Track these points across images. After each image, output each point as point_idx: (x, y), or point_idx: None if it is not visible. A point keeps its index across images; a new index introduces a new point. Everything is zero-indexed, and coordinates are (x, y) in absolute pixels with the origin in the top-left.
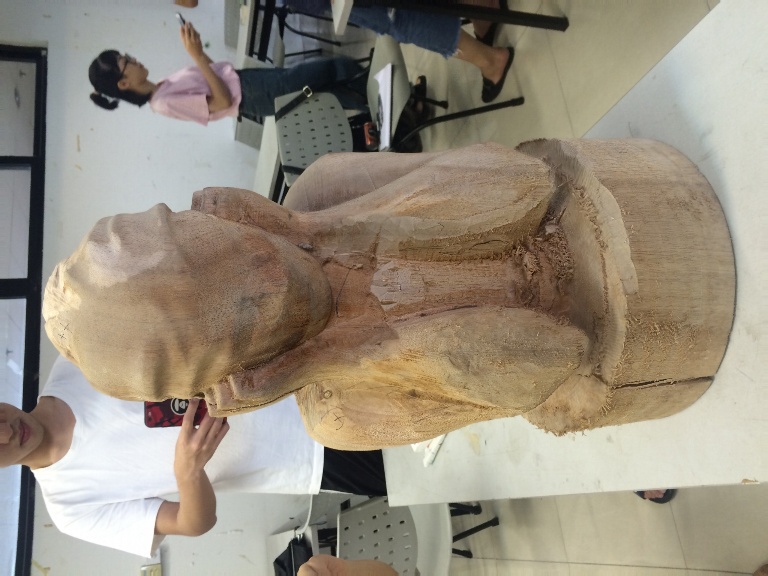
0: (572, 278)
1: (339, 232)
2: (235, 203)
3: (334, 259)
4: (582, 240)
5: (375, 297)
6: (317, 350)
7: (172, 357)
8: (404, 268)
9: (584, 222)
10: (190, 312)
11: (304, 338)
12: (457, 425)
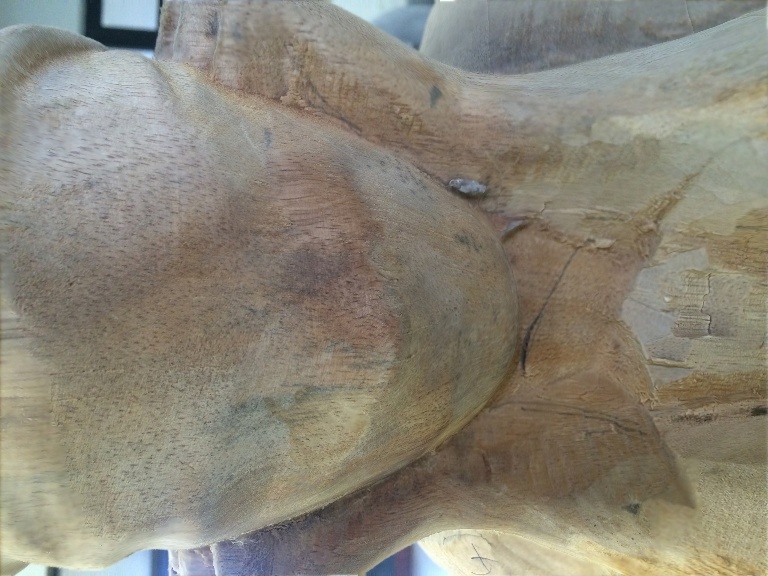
0: None
1: (573, 156)
2: (269, 41)
3: (540, 221)
4: None
5: (632, 337)
6: (457, 486)
7: (10, 554)
8: (733, 273)
9: None
10: (40, 461)
11: None
12: None
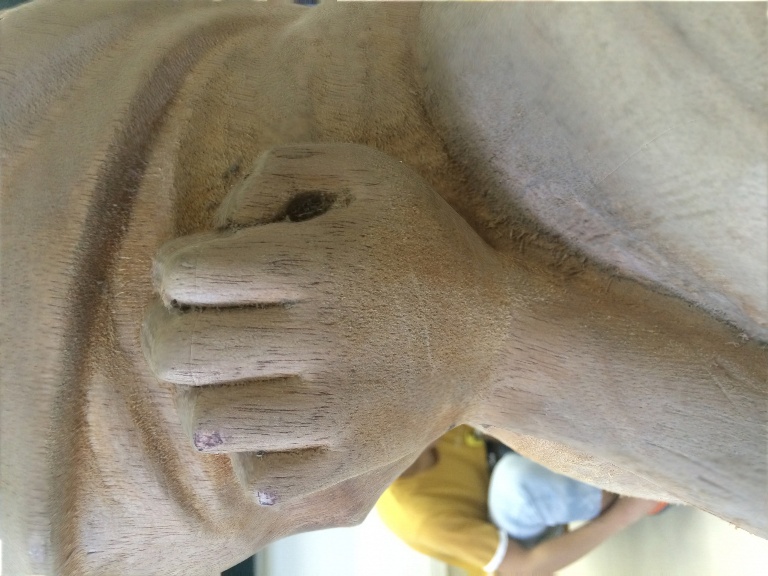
0: None
1: None
2: None
3: None
4: None
5: None
6: None
7: None
8: None
9: None
10: None
11: None
12: None
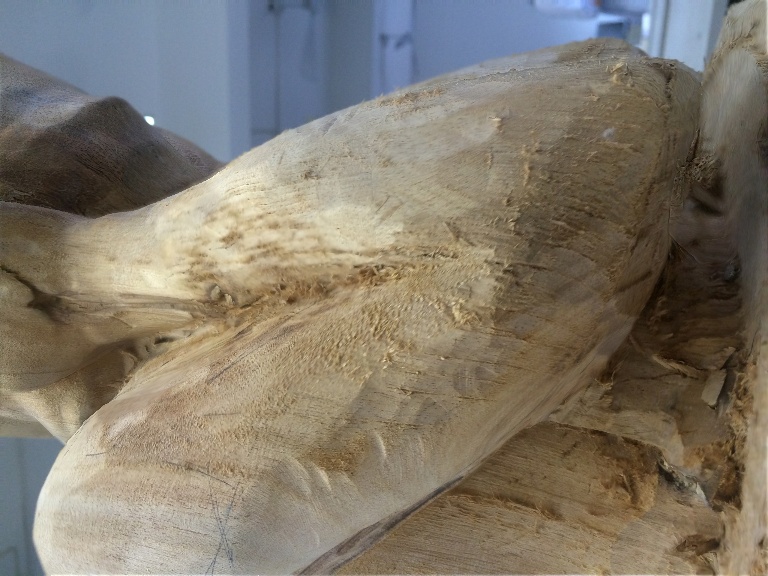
0: (718, 176)
1: None
2: None
3: None
4: (720, 105)
5: None
6: None
7: None
8: None
9: (717, 81)
10: None
11: (98, 213)
12: (309, 379)
